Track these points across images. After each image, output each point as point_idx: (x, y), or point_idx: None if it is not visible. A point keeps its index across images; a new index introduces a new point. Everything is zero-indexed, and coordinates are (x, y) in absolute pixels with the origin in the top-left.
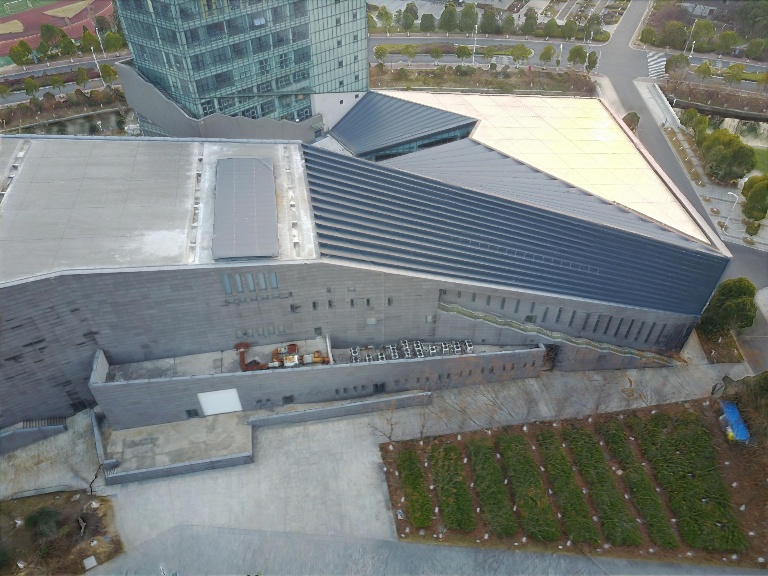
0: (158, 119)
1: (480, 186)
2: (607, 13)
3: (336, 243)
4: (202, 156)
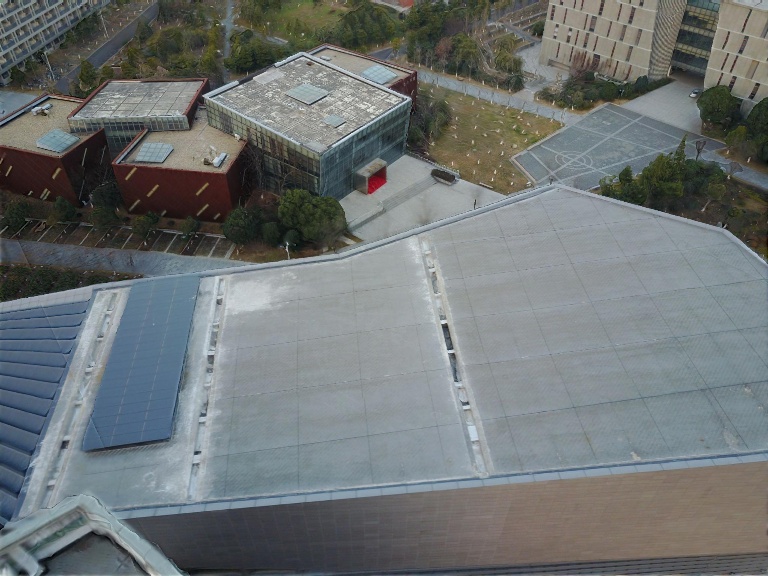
0: None
1: None
2: None
3: (66, 319)
4: (194, 461)
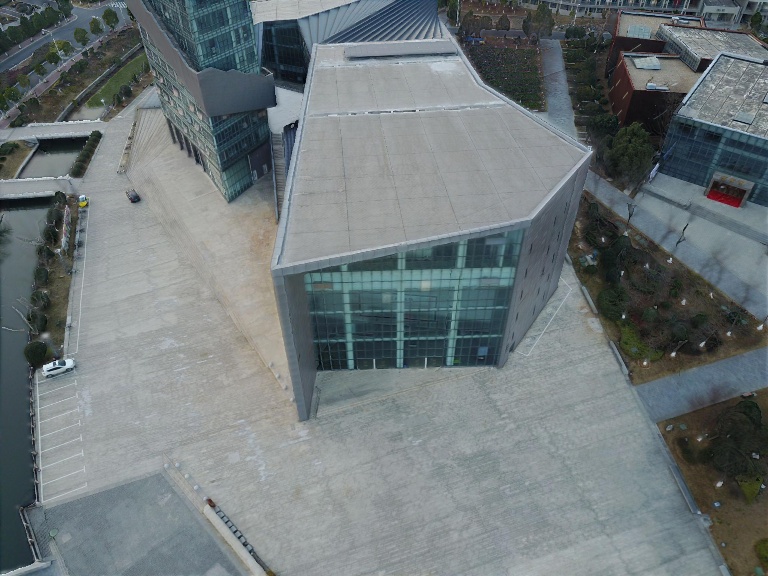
0: (237, 105)
1: None
2: (19, 5)
3: None
4: None
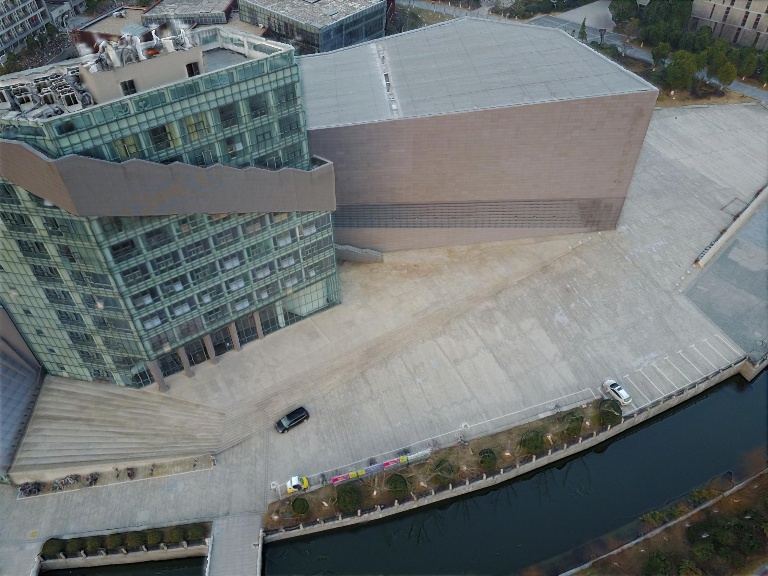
0: None
1: None
2: None
3: None
4: None
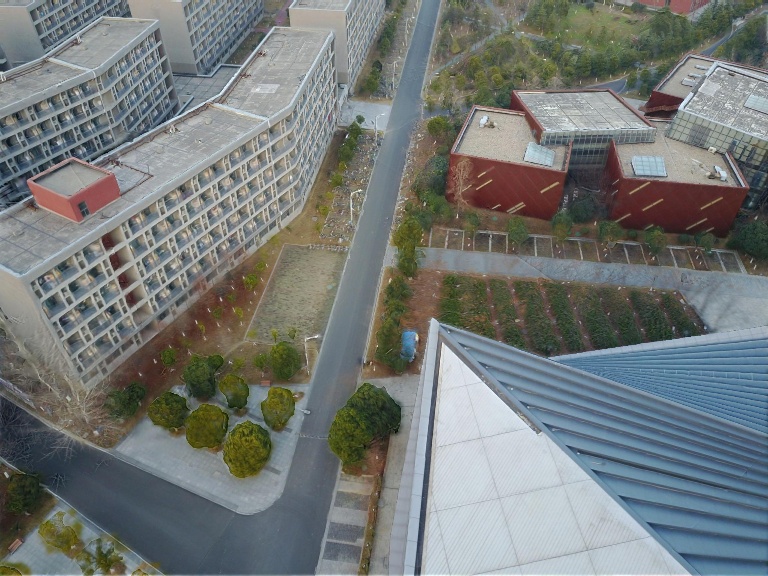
0: None
1: (748, 473)
2: None
3: None
4: None
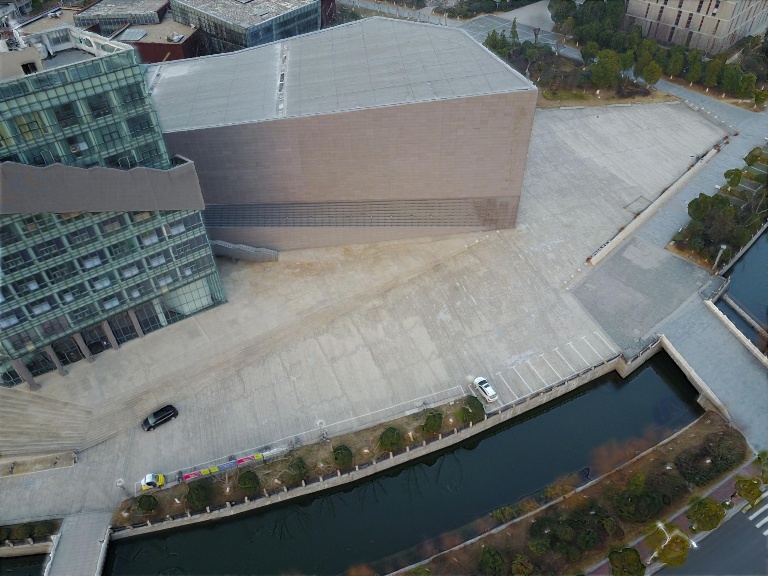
0: None
1: None
2: None
3: None
4: None
